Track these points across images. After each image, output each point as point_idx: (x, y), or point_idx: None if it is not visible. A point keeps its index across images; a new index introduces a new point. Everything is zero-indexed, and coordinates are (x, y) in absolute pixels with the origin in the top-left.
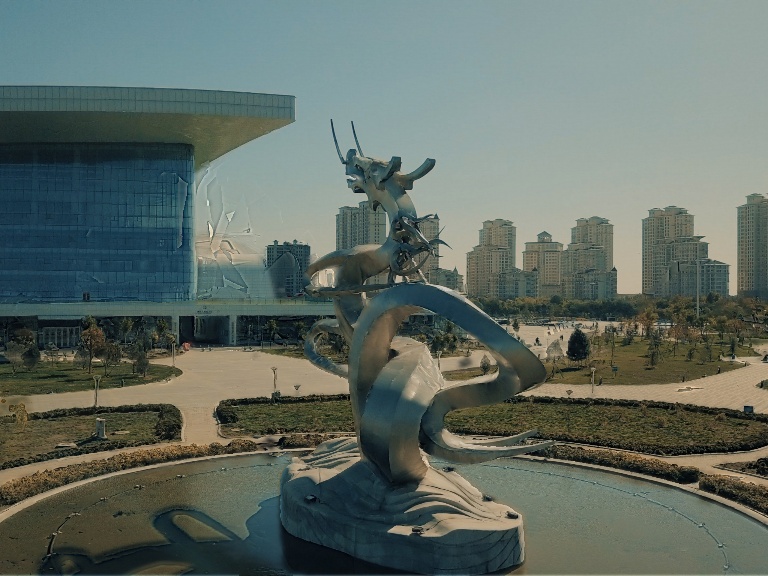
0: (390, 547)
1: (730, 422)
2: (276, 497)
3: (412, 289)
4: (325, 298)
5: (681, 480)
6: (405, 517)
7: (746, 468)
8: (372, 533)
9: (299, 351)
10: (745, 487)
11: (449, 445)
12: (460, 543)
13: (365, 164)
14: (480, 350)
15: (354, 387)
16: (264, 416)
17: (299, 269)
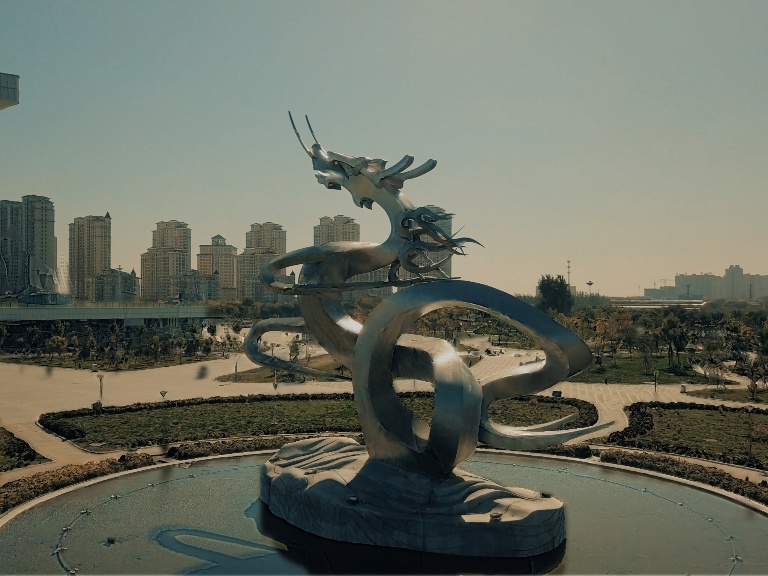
0: (469, 536)
1: (544, 406)
2: (251, 507)
3: (452, 285)
4: (46, 301)
5: (578, 456)
6: (465, 506)
7: (607, 442)
8: (446, 525)
9: (37, 359)
10: (642, 456)
11: (504, 433)
12: (537, 523)
13: (353, 160)
14: (231, 352)
15: (364, 385)
16: (106, 428)
17: (5, 269)
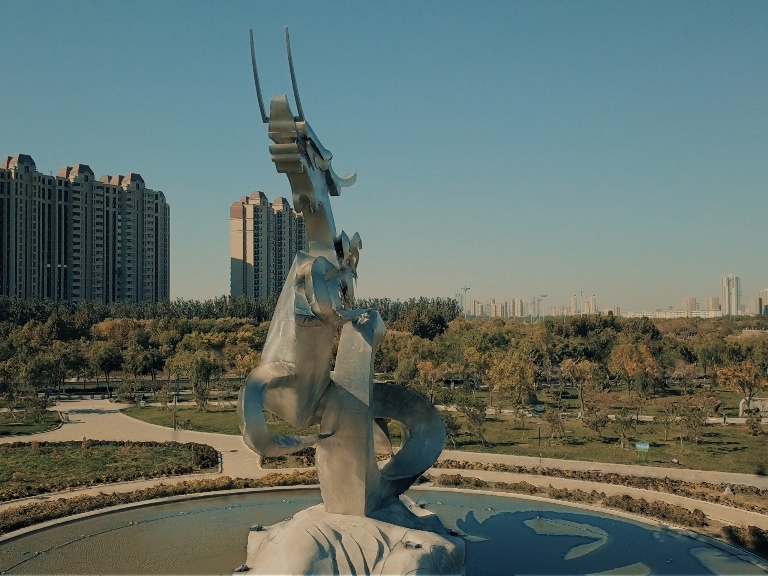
0: None
1: None
2: None
3: None
4: None
5: None
6: None
7: None
8: None
9: None
10: (1, 517)
11: None
12: None
13: None
14: None
15: None
16: None
17: None
